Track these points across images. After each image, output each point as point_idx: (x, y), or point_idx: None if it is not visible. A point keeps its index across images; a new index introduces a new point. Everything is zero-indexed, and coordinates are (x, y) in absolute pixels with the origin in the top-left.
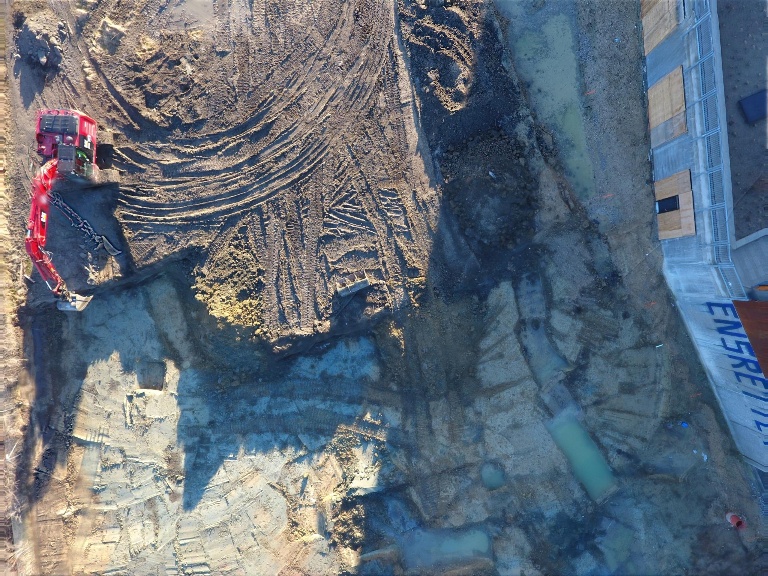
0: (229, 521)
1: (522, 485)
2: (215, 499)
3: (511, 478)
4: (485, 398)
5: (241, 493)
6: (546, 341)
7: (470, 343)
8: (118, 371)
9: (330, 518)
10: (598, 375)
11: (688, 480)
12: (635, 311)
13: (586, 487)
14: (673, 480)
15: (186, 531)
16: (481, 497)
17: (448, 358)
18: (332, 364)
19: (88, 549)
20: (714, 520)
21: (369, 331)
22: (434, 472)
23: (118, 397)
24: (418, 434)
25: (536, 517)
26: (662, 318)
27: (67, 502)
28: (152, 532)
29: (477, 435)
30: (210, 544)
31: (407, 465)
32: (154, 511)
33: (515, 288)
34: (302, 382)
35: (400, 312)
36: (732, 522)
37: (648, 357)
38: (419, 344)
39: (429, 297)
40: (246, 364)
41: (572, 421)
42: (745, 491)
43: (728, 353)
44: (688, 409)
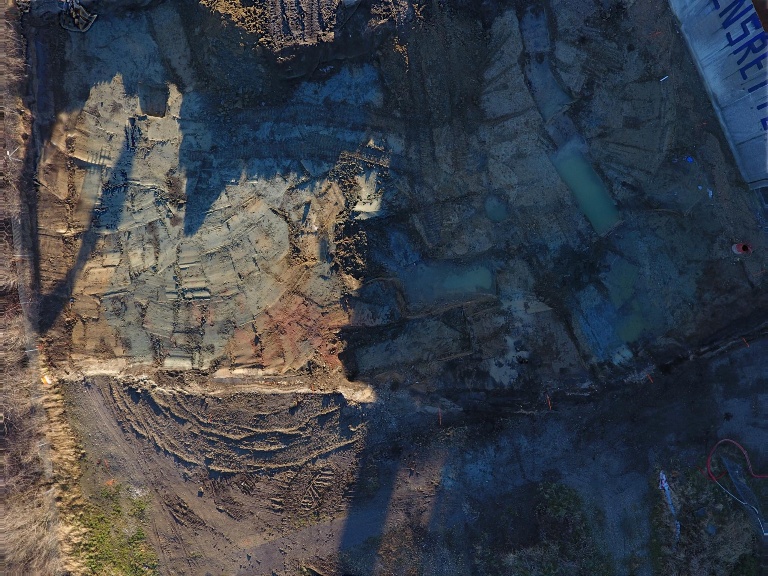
0: (230, 246)
1: (526, 216)
2: (216, 224)
3: (515, 209)
4: (489, 127)
5: (243, 218)
6: (550, 75)
7: (474, 70)
8: (121, 93)
9: (332, 240)
10: (602, 107)
11: (693, 215)
12: (640, 43)
13: (590, 220)
14: (678, 214)
15: (187, 255)
16: (485, 227)
17: (452, 77)
18: (335, 90)
19: (88, 272)
20: (720, 254)
21: (373, 55)
22: (437, 200)
23: (120, 120)
24: (421, 161)
25: (540, 248)
26: (667, 47)
27: (67, 223)
28: (152, 255)
29: (481, 164)
30: (211, 269)
31: (410, 192)
32: (155, 235)
33: (519, 19)
34: (305, 107)
35: (404, 27)
36: (738, 248)
37: (653, 92)
38: (423, 57)
39: (433, 11)
40: (249, 83)
41: (576, 155)
42: (751, 223)
43: (734, 49)
44: (693, 139)
